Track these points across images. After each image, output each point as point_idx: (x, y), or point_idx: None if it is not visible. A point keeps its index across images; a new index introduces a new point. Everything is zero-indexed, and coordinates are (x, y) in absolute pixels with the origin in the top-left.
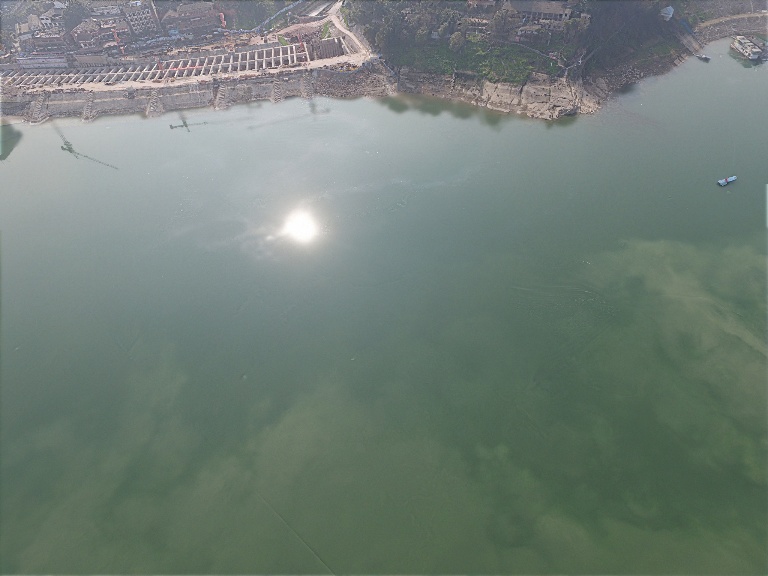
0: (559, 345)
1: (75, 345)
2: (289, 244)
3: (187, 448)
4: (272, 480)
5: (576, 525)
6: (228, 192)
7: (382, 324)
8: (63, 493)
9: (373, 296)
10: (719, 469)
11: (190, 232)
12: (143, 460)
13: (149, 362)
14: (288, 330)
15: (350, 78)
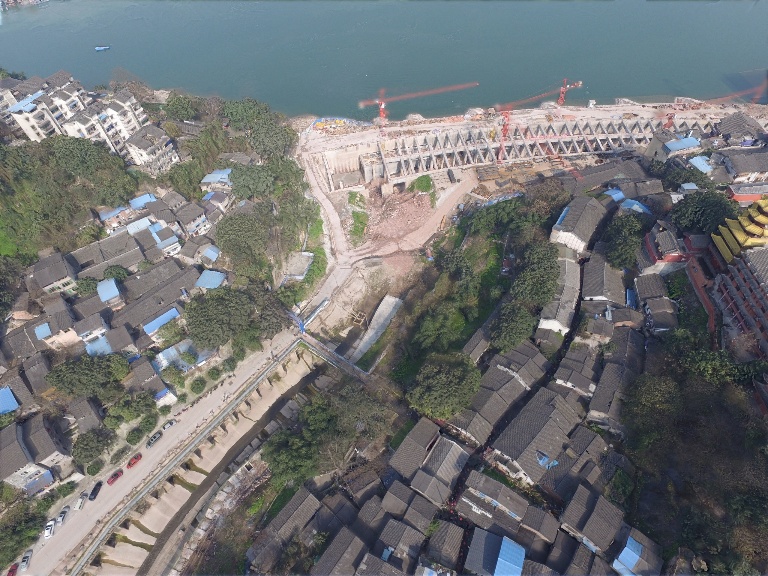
0: None
1: None
2: (379, 18)
3: None
4: None
5: None
6: None
7: (333, 3)
8: None
9: None
10: None
11: (442, 23)
12: None
13: None
14: None
15: None
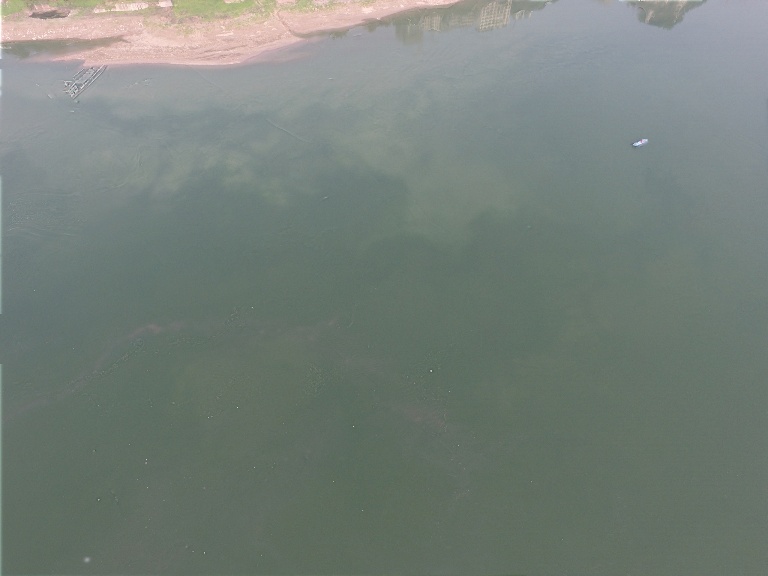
0: (79, 201)
1: (471, 216)
2: (279, 294)
3: (359, 164)
4: (305, 150)
5: (148, 134)
6: (372, 411)
7: (208, 219)
8: (430, 153)
9: (206, 239)
10: (55, 131)
11: (405, 326)
12: (388, 164)
13: (397, 194)
14: (289, 220)
15: None
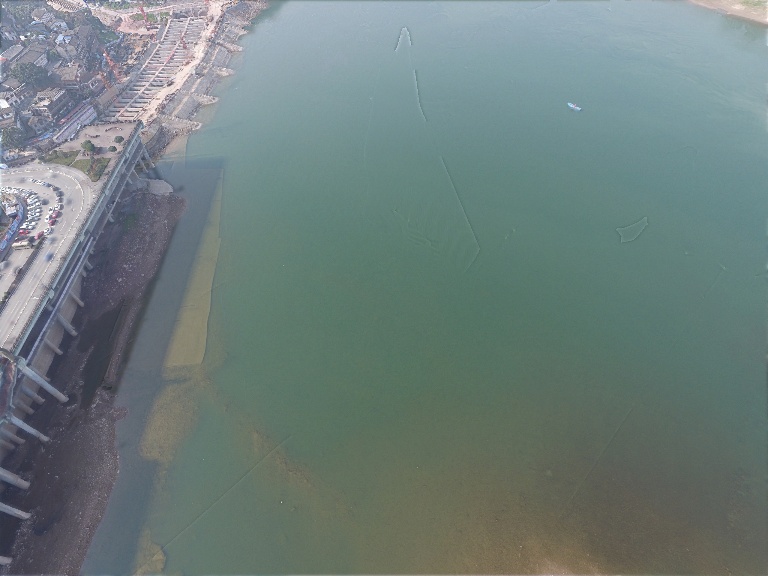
0: None
1: None
2: (406, 11)
3: (512, 24)
4: None
5: None
6: None
7: None
8: None
9: None
10: None
11: (390, 34)
12: (517, 33)
13: None
14: None
15: (244, 5)
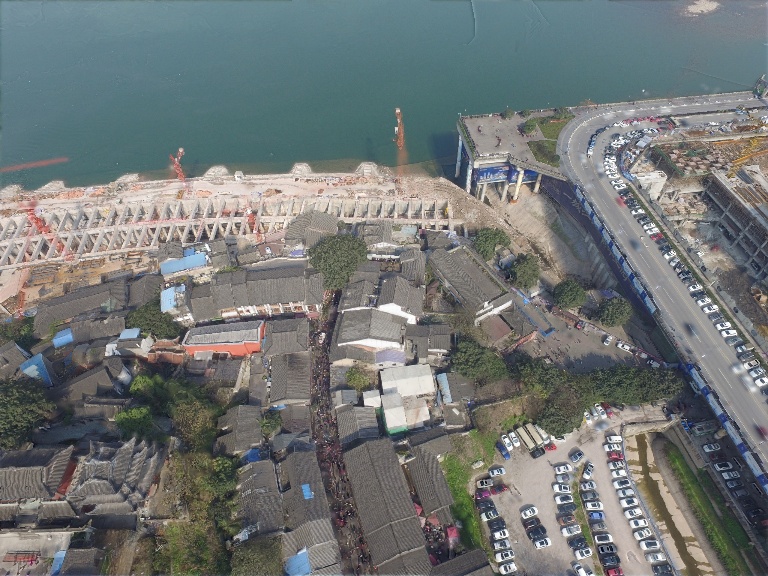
0: (3, 30)
1: None
2: (108, 53)
3: None
4: (150, 6)
5: None
6: (143, 88)
7: (78, 32)
8: (230, 4)
9: None
10: None
11: (173, 61)
12: None
13: None
14: None
15: None
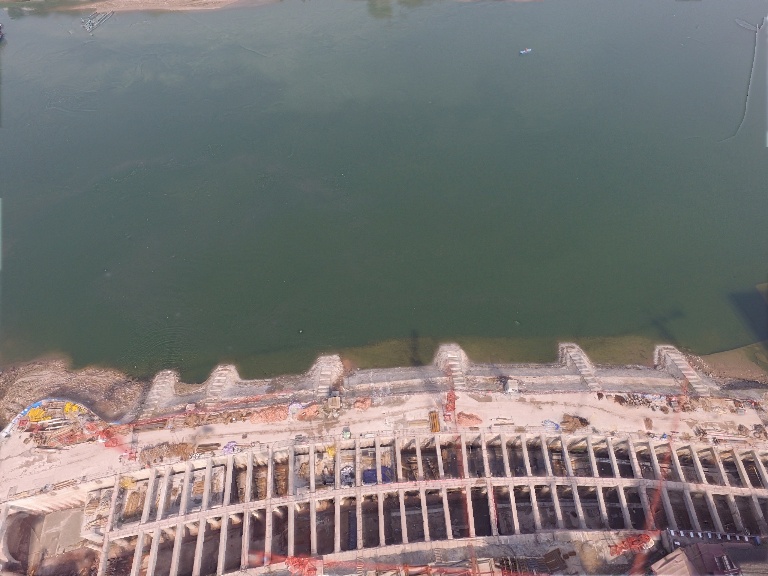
0: (96, 94)
1: (386, 95)
2: (241, 137)
3: None
4: (268, 62)
5: None
6: (300, 195)
7: (192, 101)
8: None
9: (190, 111)
10: (76, 51)
11: (328, 152)
12: None
13: None
14: None
15: (63, 393)
